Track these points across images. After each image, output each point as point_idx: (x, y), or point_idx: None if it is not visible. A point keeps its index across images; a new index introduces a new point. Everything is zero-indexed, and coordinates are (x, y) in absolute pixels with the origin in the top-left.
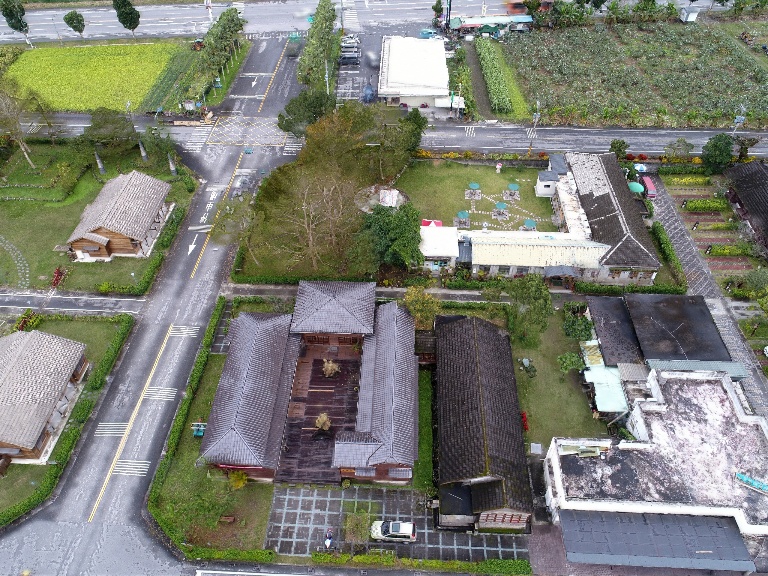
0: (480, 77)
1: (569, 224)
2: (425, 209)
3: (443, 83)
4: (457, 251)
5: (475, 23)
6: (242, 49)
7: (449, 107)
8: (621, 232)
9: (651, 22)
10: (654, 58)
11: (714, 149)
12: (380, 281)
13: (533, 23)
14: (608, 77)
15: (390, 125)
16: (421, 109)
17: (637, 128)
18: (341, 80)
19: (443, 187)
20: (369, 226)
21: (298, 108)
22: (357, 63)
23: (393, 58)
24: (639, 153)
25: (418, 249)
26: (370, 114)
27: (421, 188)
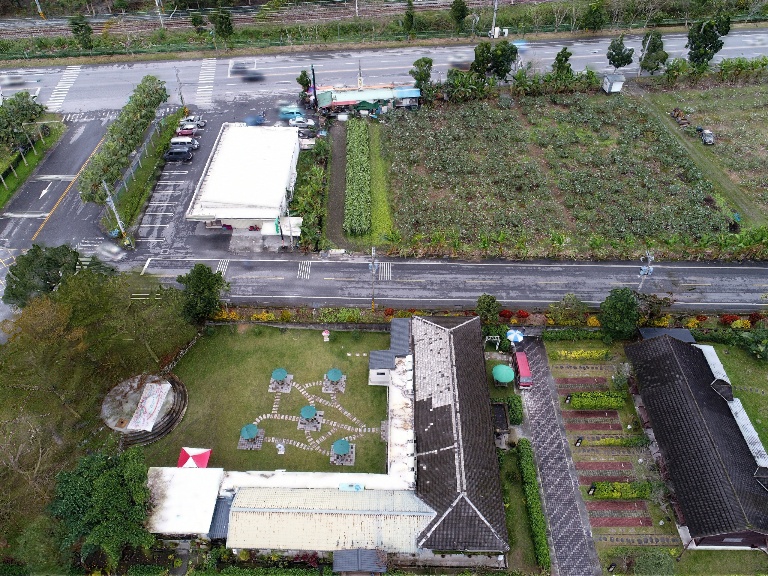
0: (343, 176)
1: (391, 456)
2: (205, 414)
3: (276, 199)
4: (208, 521)
5: (348, 100)
6: (50, 138)
7: (279, 235)
8: (453, 488)
9: (568, 92)
10: (565, 145)
11: (613, 311)
12: (89, 572)
13: (423, 97)
14: (500, 178)
15: (201, 260)
16: (249, 232)
17: (525, 261)
18: (160, 186)
19: (242, 371)
20: (62, 497)
21: (23, 272)
22: (188, 159)
23: (221, 160)
24: (521, 304)
25: (140, 530)
26: (103, 296)
27: (210, 374)
